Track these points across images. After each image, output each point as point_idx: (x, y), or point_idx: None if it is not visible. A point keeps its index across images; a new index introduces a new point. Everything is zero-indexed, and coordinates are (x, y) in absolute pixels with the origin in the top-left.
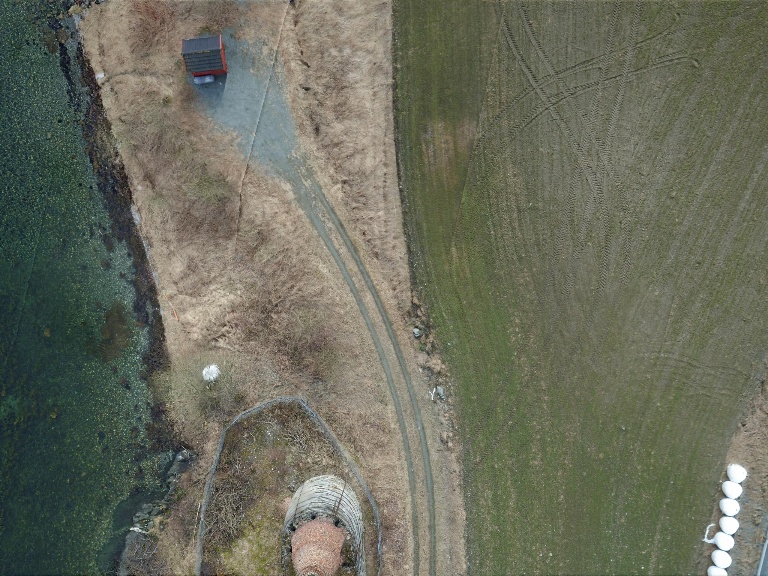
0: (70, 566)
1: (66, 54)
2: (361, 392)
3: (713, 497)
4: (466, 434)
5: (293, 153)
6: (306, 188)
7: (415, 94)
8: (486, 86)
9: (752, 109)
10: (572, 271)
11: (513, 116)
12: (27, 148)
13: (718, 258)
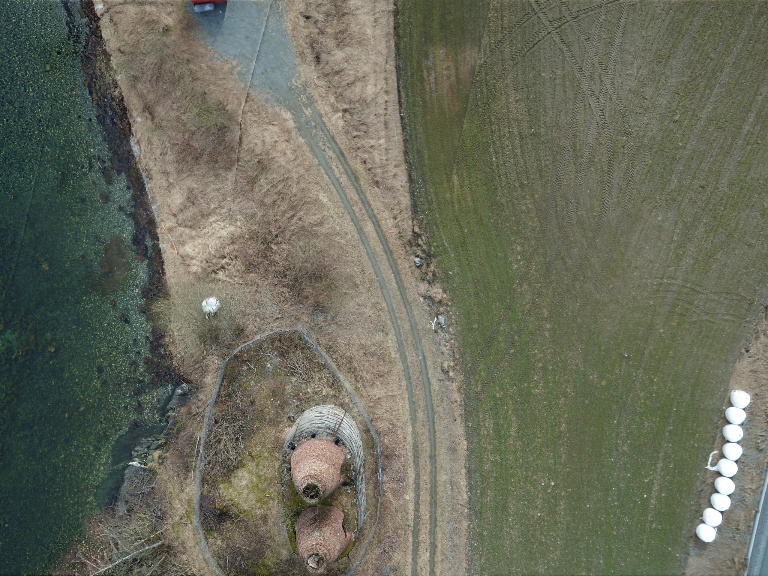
0: (68, 501)
1: None
2: (361, 322)
3: (716, 424)
4: (467, 363)
5: (293, 81)
6: (306, 116)
7: (416, 20)
8: (488, 11)
9: (756, 30)
10: (574, 197)
11: (515, 41)
12: (26, 80)
13: (722, 182)
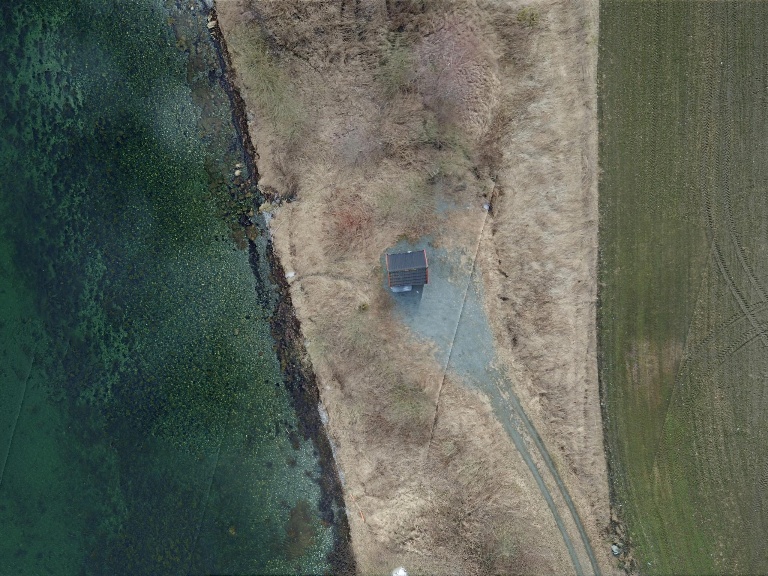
0: None
1: (255, 251)
2: None
3: None
4: None
5: (491, 364)
6: (504, 400)
7: (620, 313)
8: (694, 309)
9: None
10: None
11: (722, 340)
12: (214, 343)
13: None
